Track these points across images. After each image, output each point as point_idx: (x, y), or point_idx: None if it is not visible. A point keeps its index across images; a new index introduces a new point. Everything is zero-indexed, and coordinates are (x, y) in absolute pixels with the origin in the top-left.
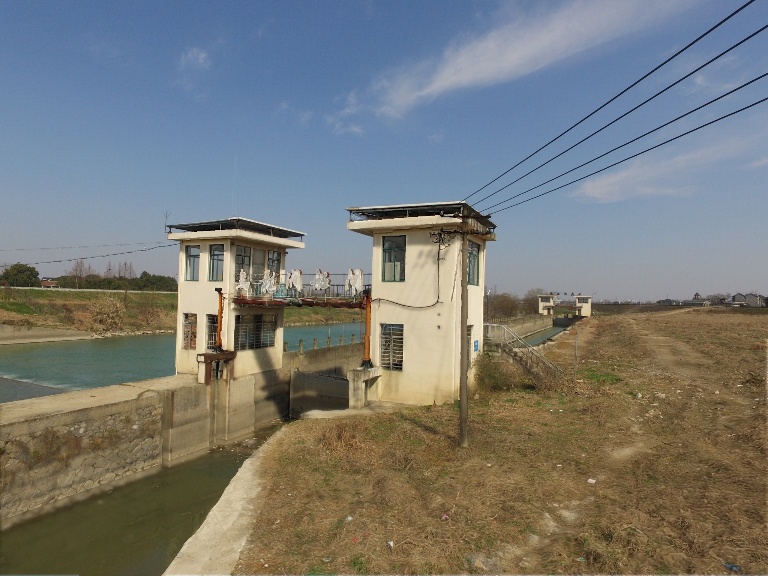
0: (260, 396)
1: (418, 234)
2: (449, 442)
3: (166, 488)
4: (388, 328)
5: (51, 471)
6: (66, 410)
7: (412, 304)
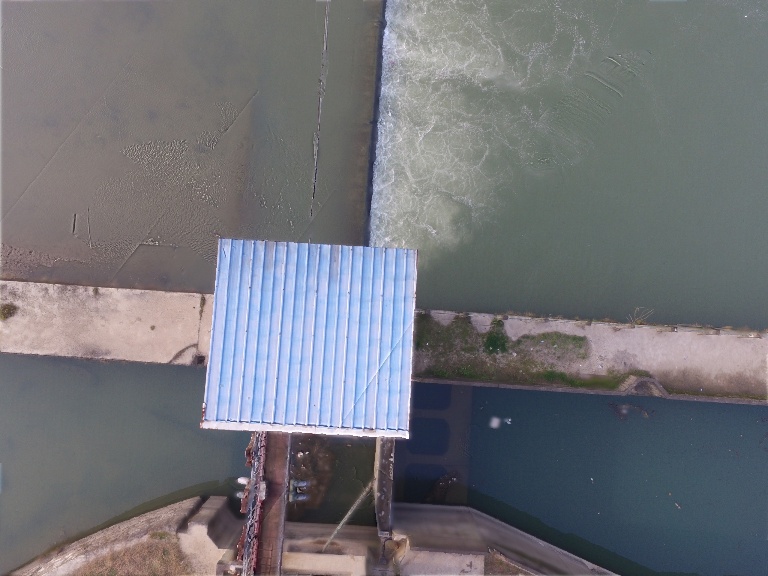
0: None
1: None
2: None
3: None
4: None
5: None
6: (111, 355)
7: None
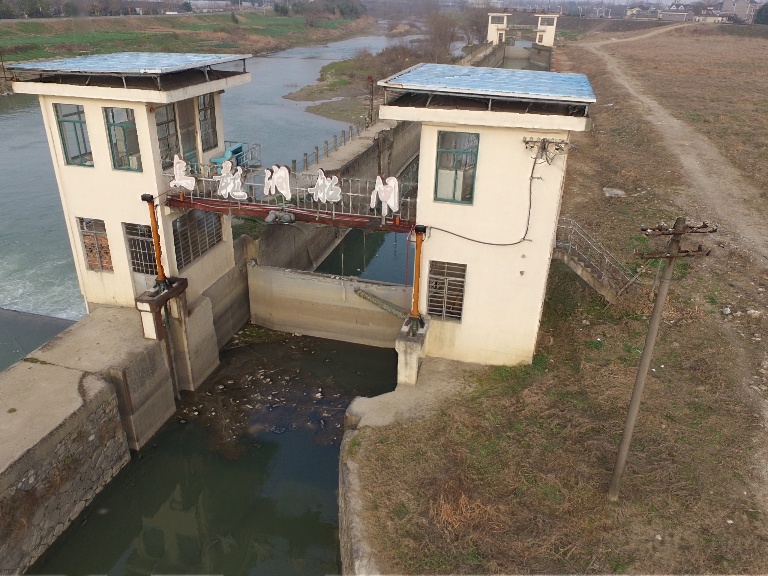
0: (216, 314)
1: (501, 135)
2: (592, 491)
3: (142, 480)
4: (441, 265)
5: (13, 544)
6: (1, 464)
7: (483, 238)
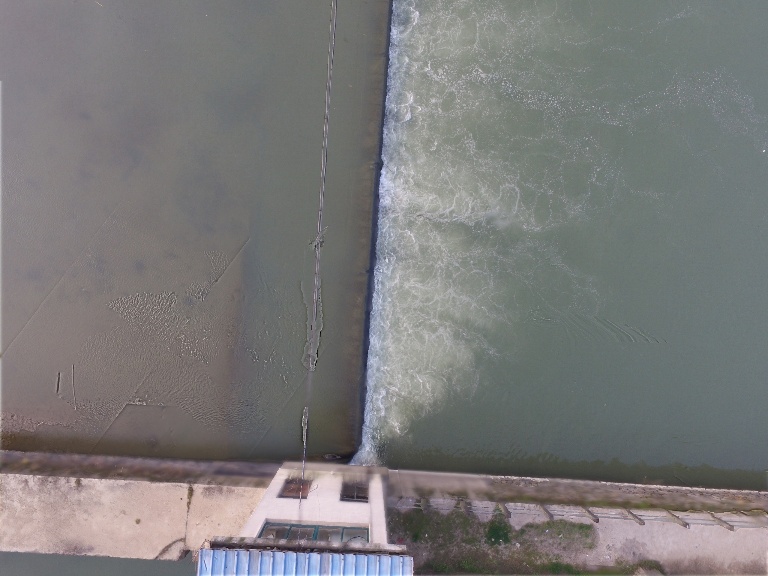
0: None
1: None
2: None
3: None
4: None
5: None
6: (94, 551)
7: None
